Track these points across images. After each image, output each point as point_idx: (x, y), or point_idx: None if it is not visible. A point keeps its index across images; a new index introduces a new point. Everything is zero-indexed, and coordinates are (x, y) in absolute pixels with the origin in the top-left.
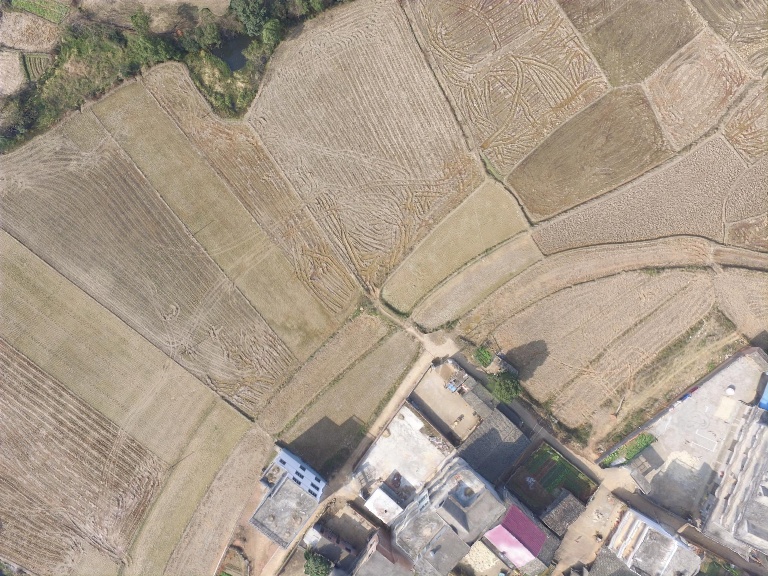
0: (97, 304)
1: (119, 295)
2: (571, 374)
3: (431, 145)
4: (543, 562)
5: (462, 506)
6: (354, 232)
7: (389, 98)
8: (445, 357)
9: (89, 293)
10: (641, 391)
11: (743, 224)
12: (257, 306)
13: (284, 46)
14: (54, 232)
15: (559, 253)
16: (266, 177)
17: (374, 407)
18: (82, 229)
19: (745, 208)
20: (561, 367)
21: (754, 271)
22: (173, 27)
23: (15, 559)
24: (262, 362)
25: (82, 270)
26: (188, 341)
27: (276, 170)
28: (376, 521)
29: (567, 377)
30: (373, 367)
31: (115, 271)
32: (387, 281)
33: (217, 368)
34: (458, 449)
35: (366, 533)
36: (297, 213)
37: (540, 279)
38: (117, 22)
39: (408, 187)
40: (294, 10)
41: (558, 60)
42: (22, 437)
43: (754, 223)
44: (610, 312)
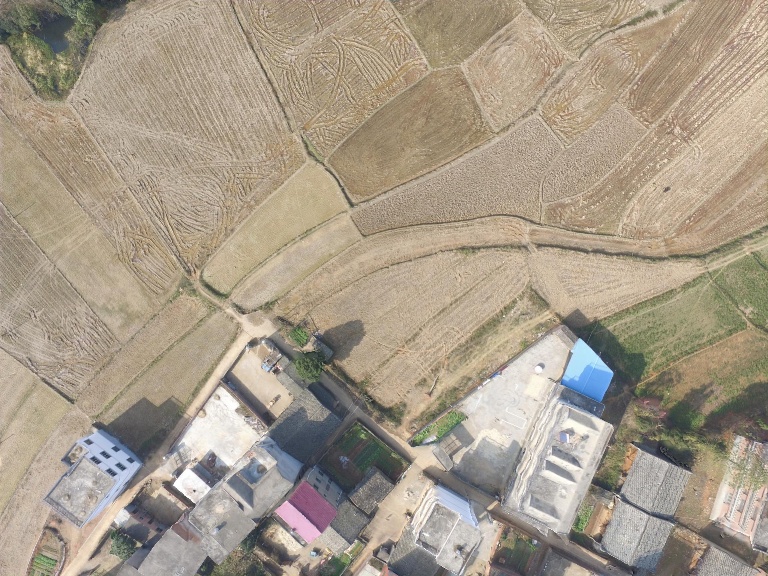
0: None
1: None
2: (387, 354)
3: (253, 127)
4: (346, 539)
5: (249, 483)
6: (176, 214)
7: (211, 80)
8: (263, 338)
9: None
10: (455, 370)
11: (559, 204)
12: (78, 288)
13: (107, 28)
14: None
15: (377, 234)
16: (88, 159)
17: (192, 388)
18: None
19: (561, 188)
20: (377, 347)
21: (567, 250)
22: None
23: None
24: (83, 344)
25: None
26: (9, 323)
27: (98, 152)
28: (191, 501)
29: (383, 357)
30: (192, 348)
31: None
32: (208, 262)
33: (38, 350)
34: (268, 428)
35: (181, 513)
36: (119, 195)
37: (358, 259)
38: None
39: (230, 169)
40: None
41: (379, 42)
42: None
43: (570, 203)
44: (426, 292)
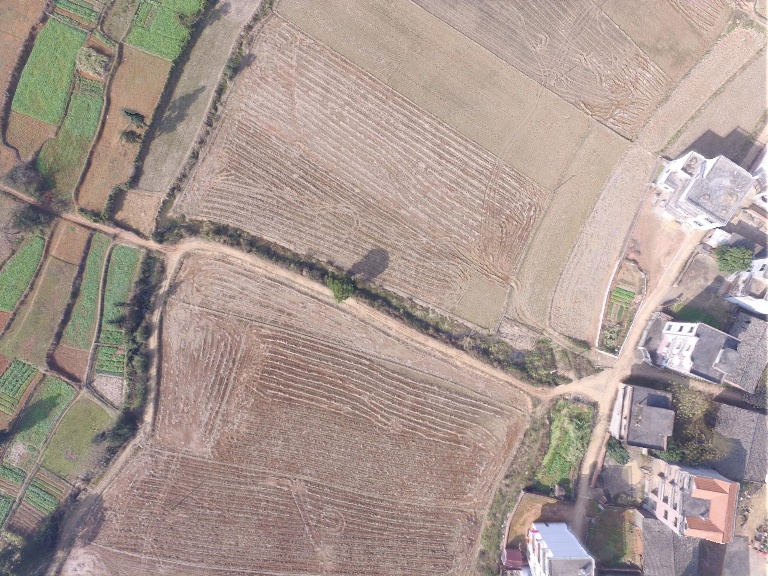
0: (466, 38)
1: (487, 28)
2: None
3: None
4: None
5: None
6: None
7: None
8: None
9: (457, 29)
10: None
11: None
12: (627, 30)
13: None
14: None
15: None
16: None
17: (759, 117)
18: None
19: None
20: None
21: None
22: None
23: (404, 289)
24: (635, 84)
25: (449, 7)
26: (559, 69)
27: None
28: None
29: None
30: (754, 78)
31: (481, 5)
32: None
33: (590, 93)
34: None
35: (766, 237)
36: None
37: None
38: None
39: None
40: None
41: None
42: (402, 171)
43: None
44: None
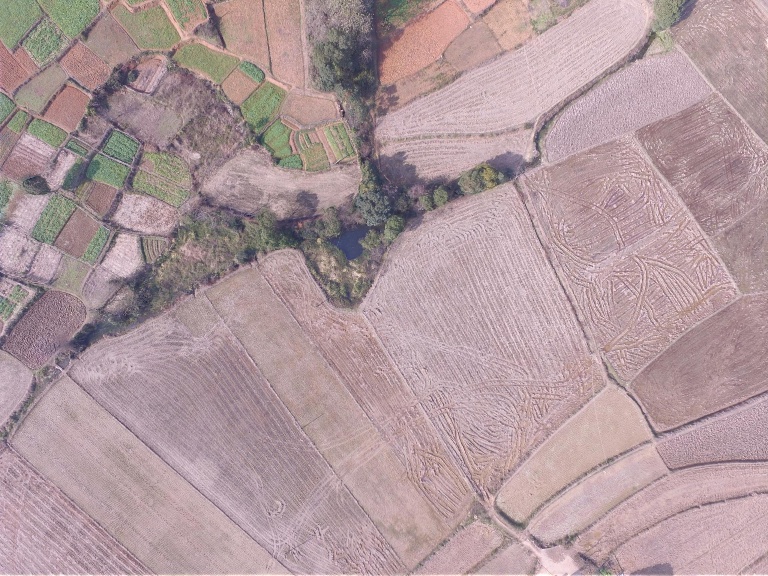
0: (201, 496)
1: (224, 488)
2: None
3: (550, 345)
4: None
5: None
6: (468, 433)
7: (508, 294)
8: (564, 575)
9: (193, 484)
10: None
11: None
12: (365, 506)
13: (402, 237)
14: (161, 419)
15: (686, 469)
16: (379, 371)
17: None
18: (190, 417)
19: None
20: None
21: None
22: (291, 214)
23: None
24: (368, 567)
25: (188, 460)
26: (292, 540)
27: (389, 364)
28: None
29: None
30: None
31: (221, 462)
32: (502, 488)
33: (321, 571)
34: None
35: None
36: (410, 410)
37: (665, 496)
38: (235, 207)
39: (526, 388)
40: (415, 204)
41: (684, 263)
42: None
43: None
44: (741, 537)
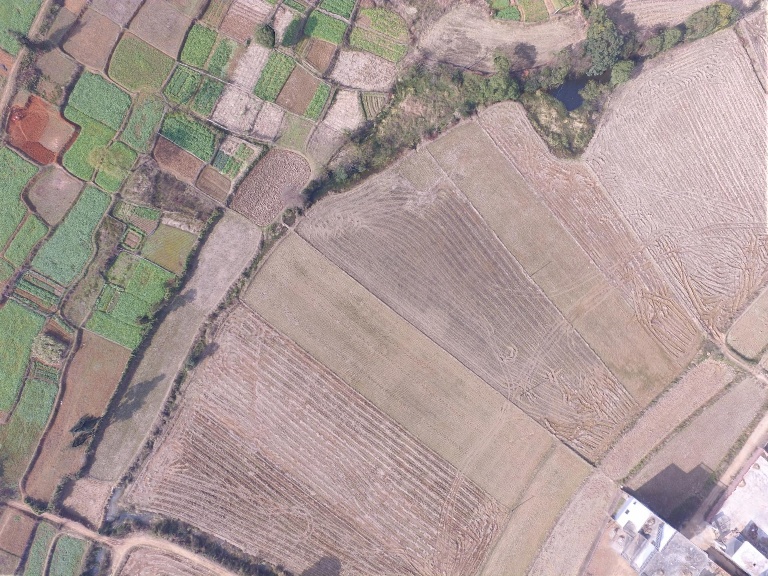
0: (434, 344)
1: (456, 335)
2: None
3: None
4: None
5: None
6: (696, 275)
7: (731, 139)
8: None
9: (426, 333)
10: None
11: None
12: (596, 349)
13: (622, 86)
14: (390, 271)
15: None
16: (604, 218)
17: (723, 455)
18: (419, 269)
19: None
20: None
21: None
22: (510, 66)
23: None
24: (602, 406)
25: (419, 310)
26: (526, 383)
27: (614, 211)
28: (732, 573)
29: None
30: (721, 414)
31: (452, 311)
32: (733, 326)
33: (556, 411)
34: None
35: None
36: (636, 255)
37: None
38: (454, 61)
39: (751, 230)
40: (638, 50)
41: None
42: (360, 477)
43: None
44: None
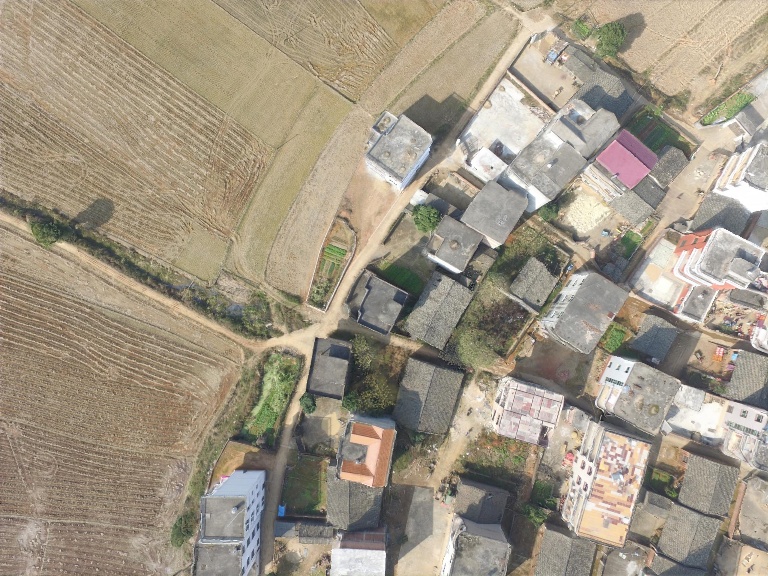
0: None
1: None
2: (669, 45)
3: None
4: (650, 205)
5: (577, 124)
6: None
7: None
8: (543, 32)
9: None
10: (739, 57)
11: None
12: None
13: None
14: None
15: None
16: None
17: (474, 84)
18: None
19: None
20: (659, 38)
21: None
22: None
23: (127, 239)
24: (362, 48)
25: None
26: (290, 29)
27: None
28: None
29: (665, 47)
30: (472, 46)
31: None
32: None
33: (319, 55)
34: None
35: (470, 200)
36: None
37: None
38: None
39: None
40: None
41: None
42: (131, 123)
43: None
44: None
